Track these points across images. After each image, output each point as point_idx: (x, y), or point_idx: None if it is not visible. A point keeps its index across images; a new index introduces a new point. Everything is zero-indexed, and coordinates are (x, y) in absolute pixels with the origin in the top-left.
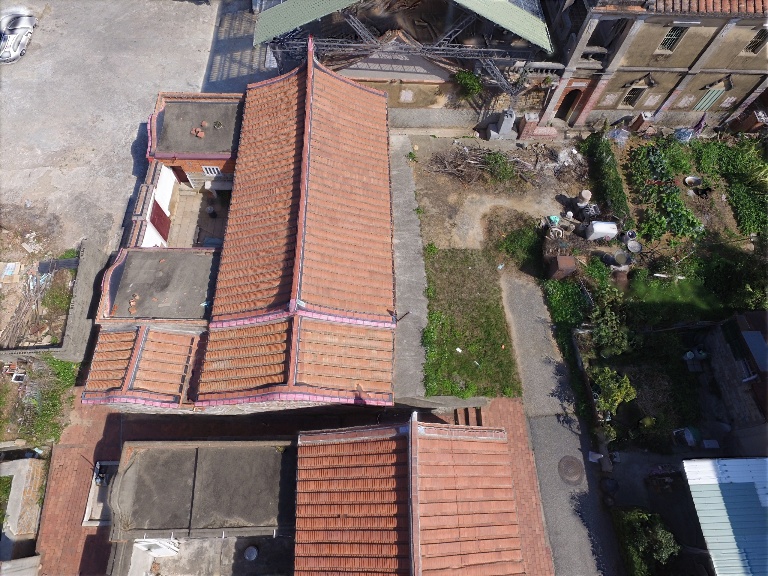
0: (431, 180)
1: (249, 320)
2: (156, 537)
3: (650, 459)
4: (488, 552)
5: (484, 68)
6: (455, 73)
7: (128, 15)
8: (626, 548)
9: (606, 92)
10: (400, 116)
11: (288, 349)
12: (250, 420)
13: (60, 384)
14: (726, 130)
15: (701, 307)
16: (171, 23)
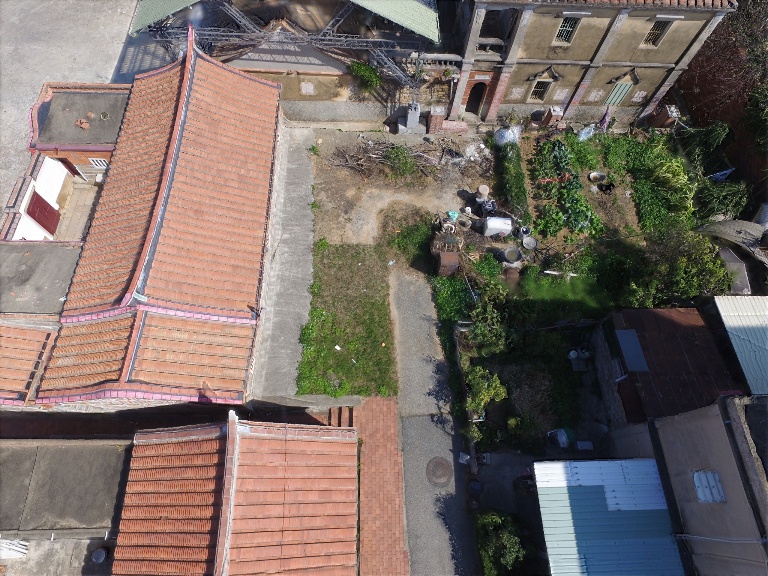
0: (331, 174)
1: (97, 315)
2: None
3: (522, 461)
4: (315, 556)
5: None
6: (350, 64)
7: (45, 6)
8: (480, 552)
9: (511, 85)
10: (306, 109)
11: None
12: (118, 418)
13: None
14: (643, 125)
15: (590, 305)
16: (88, 14)
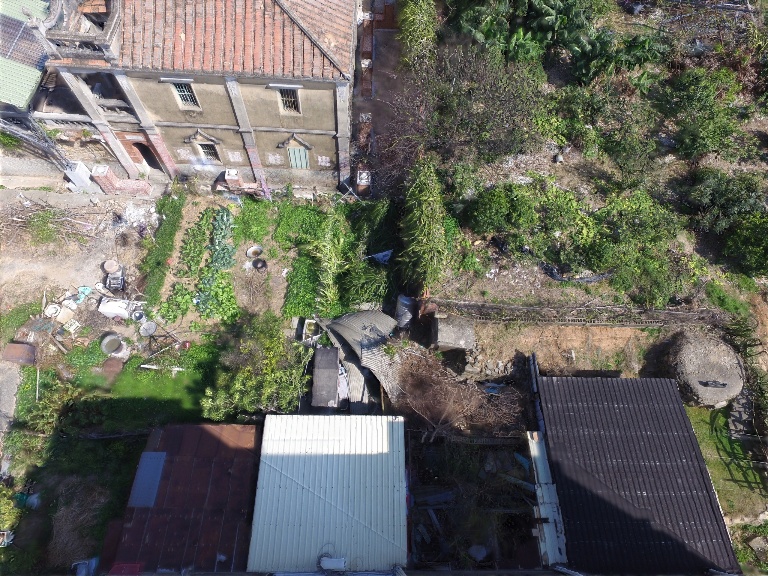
0: None
1: None
2: None
3: None
4: None
5: None
6: None
7: None
8: None
9: (172, 147)
10: None
11: None
12: None
13: None
14: None
15: (182, 407)
16: None
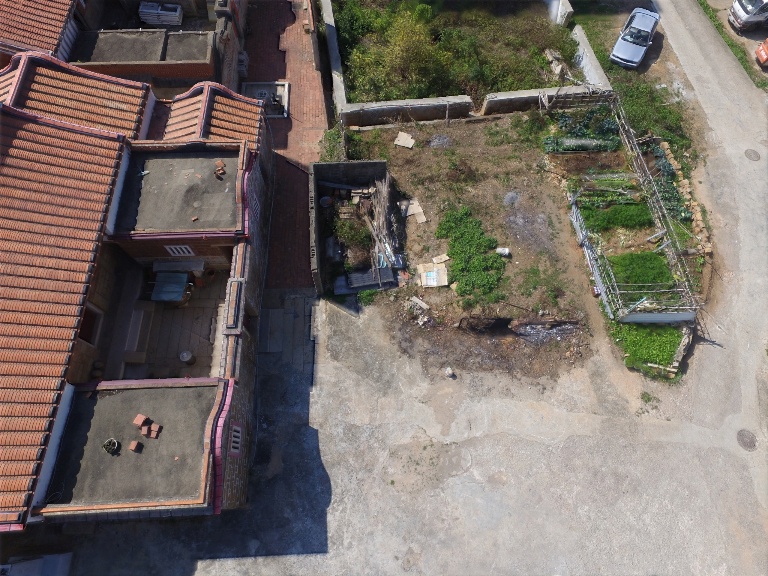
0: None
1: None
2: (193, 31)
3: None
4: None
5: None
6: None
7: None
8: None
9: None
10: None
11: (26, 90)
12: None
13: None
14: None
15: None
16: None
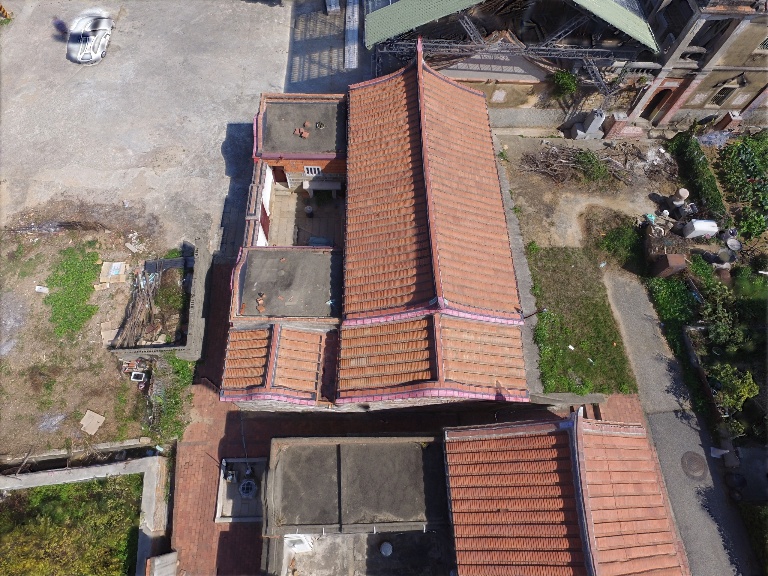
0: (524, 179)
1: (385, 318)
2: (308, 532)
3: None
4: (647, 546)
5: (583, 68)
6: (553, 73)
7: (203, 17)
8: (763, 542)
9: (696, 91)
10: None
11: (431, 346)
12: (368, 417)
13: (180, 382)
14: None
15: None
16: (247, 25)
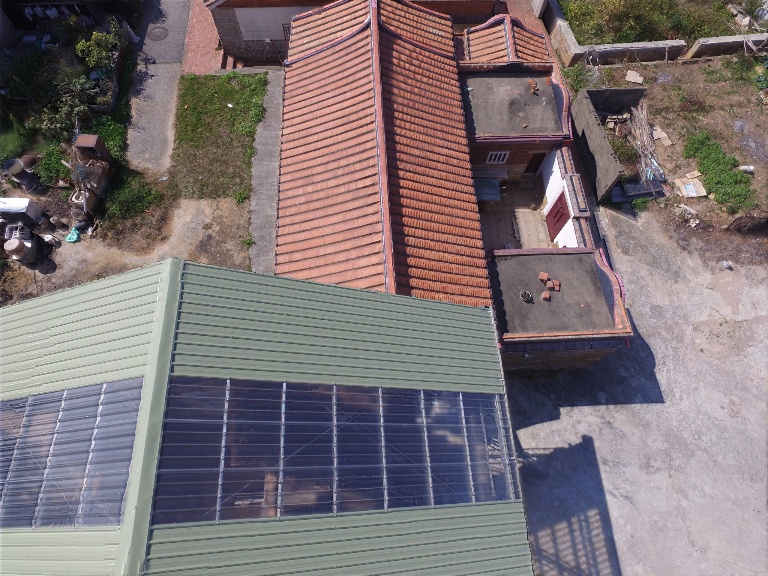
0: None
1: None
2: None
3: (89, 37)
4: None
5: None
6: None
7: None
8: None
9: None
10: None
11: (379, 14)
12: None
13: None
14: None
15: None
16: None
